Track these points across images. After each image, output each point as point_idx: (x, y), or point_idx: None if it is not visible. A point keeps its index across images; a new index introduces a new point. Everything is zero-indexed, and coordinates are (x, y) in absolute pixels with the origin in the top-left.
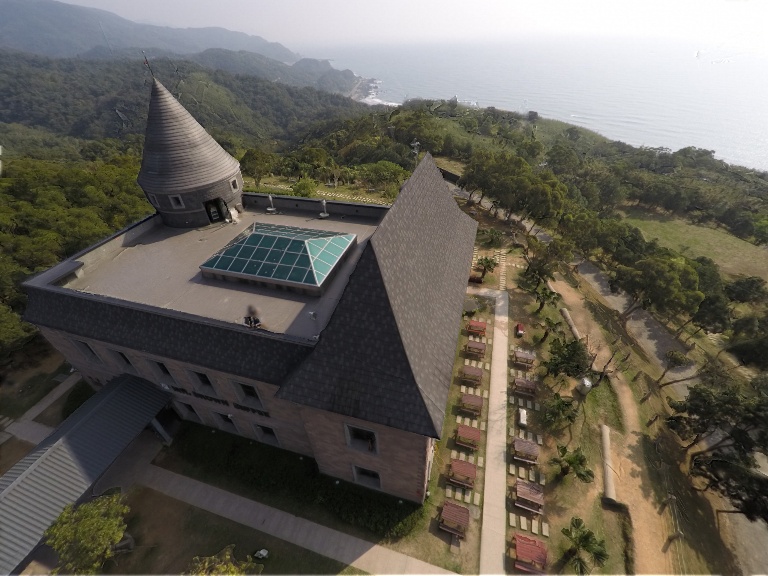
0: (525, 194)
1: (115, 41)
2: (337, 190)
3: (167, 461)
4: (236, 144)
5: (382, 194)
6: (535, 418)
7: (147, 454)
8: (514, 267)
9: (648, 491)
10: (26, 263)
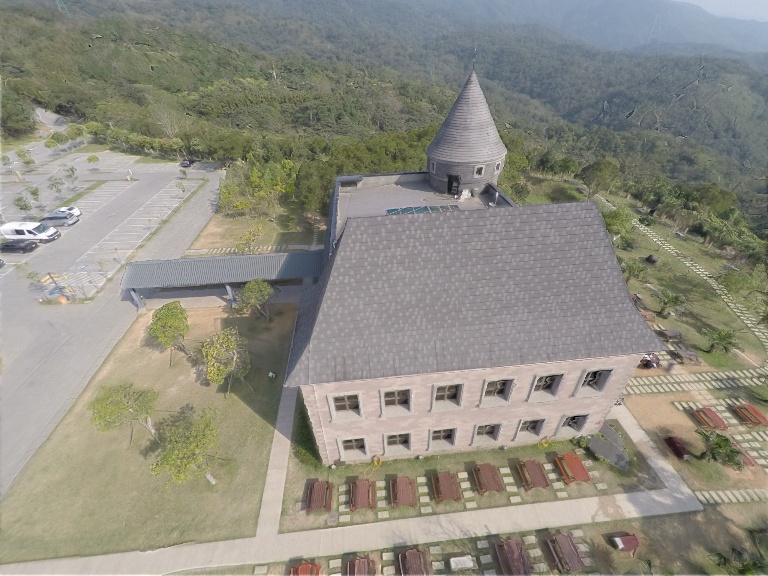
0: None
1: (658, 35)
2: (681, 244)
3: None
4: (700, 163)
5: None
6: None
7: None
8: None
9: None
10: None
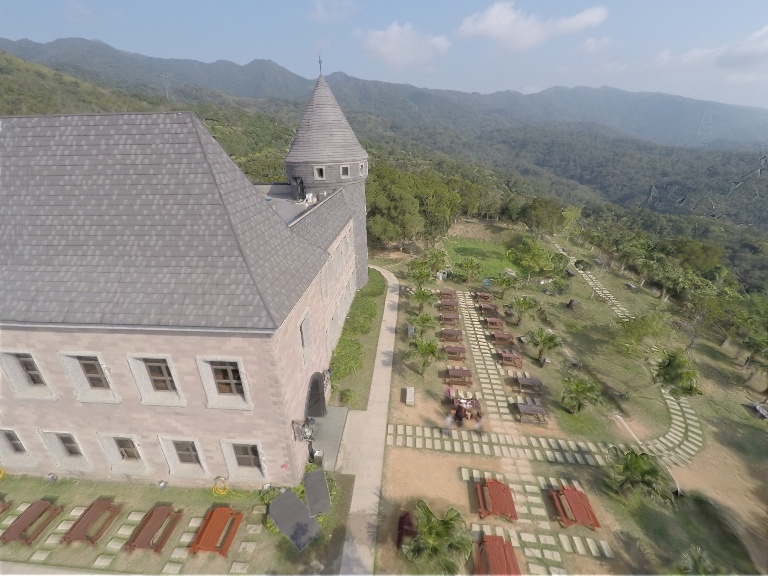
0: None
1: (709, 126)
2: (628, 296)
3: None
4: (766, 252)
5: None
6: None
7: None
8: None
9: None
10: None
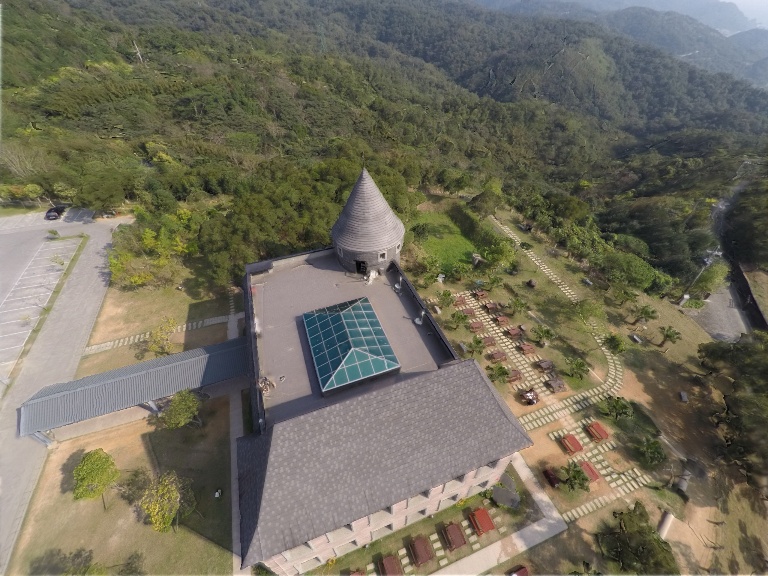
0: (757, 446)
1: (528, 4)
2: (552, 261)
3: (246, 397)
4: (570, 129)
5: (595, 294)
6: None
7: (245, 384)
8: (628, 510)
9: None
10: (284, 233)
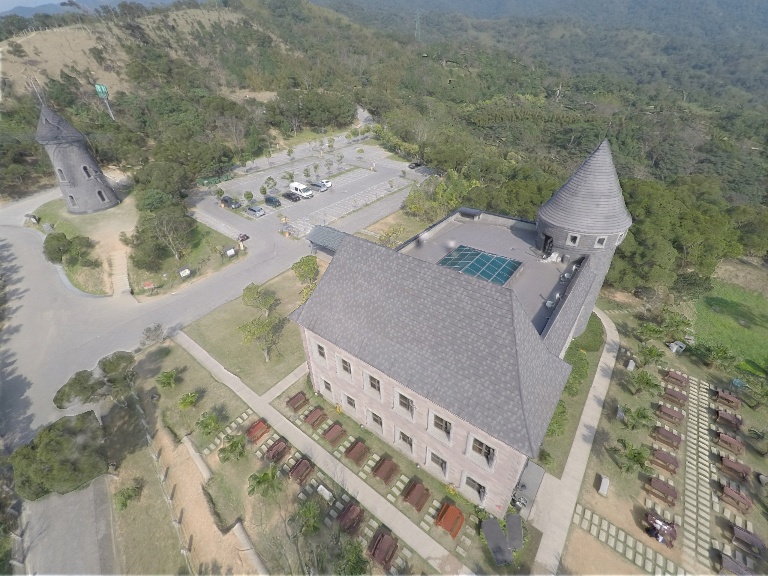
0: None
1: None
2: None
3: None
4: None
5: None
6: (320, 510)
7: None
8: None
9: (214, 573)
10: None
